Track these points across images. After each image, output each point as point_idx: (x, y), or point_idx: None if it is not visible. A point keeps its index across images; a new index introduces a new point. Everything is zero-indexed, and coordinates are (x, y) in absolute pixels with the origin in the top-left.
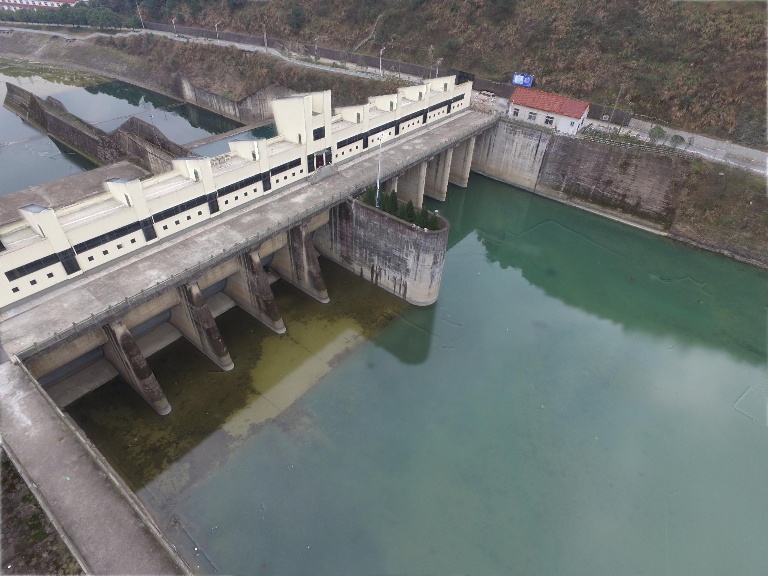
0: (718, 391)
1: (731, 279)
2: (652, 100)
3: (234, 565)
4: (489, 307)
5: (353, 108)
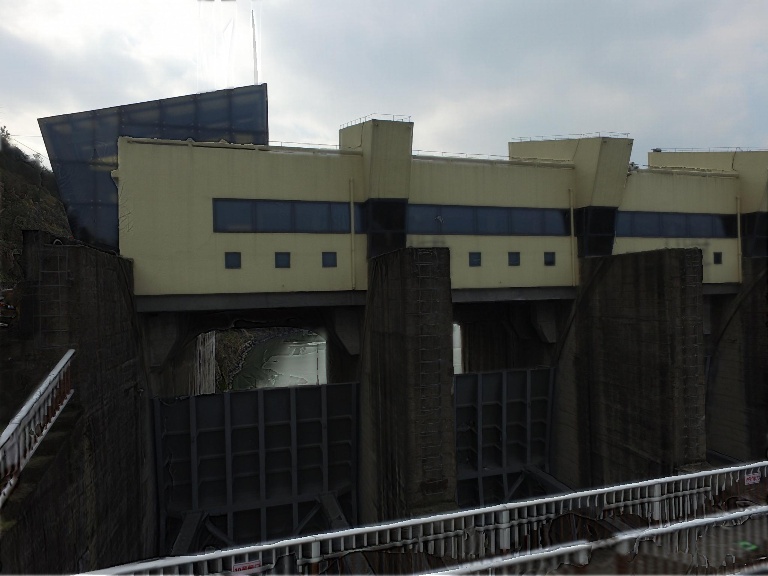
0: None
1: None
2: None
3: None
4: None
5: None
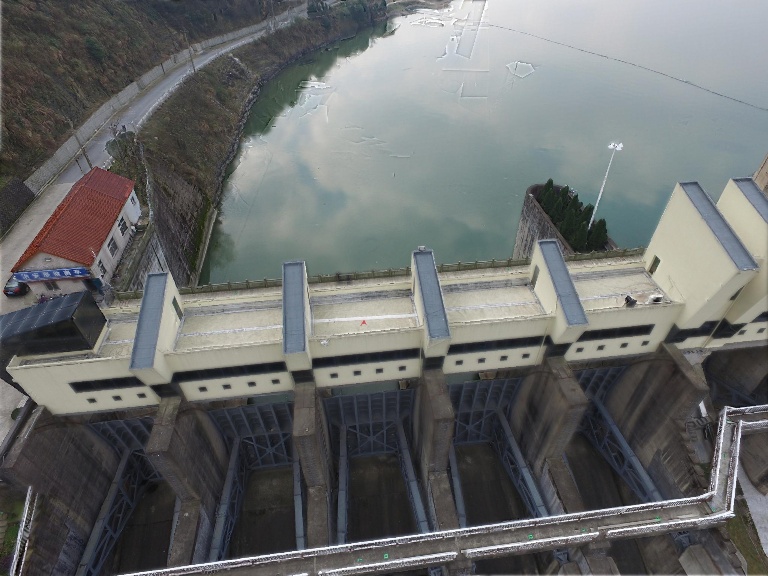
0: (407, 161)
1: None
2: (7, 144)
3: None
4: (473, 244)
5: None
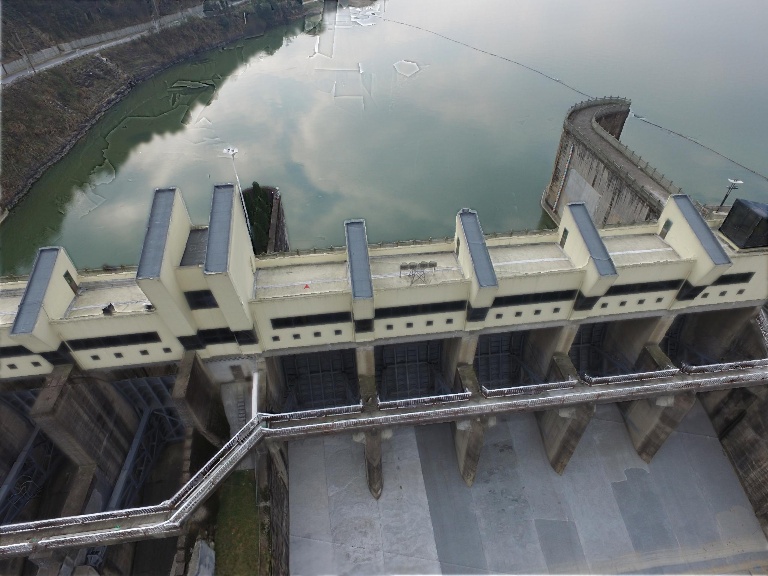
0: None
1: (40, 201)
2: None
3: (536, 224)
4: None
5: (55, 277)
